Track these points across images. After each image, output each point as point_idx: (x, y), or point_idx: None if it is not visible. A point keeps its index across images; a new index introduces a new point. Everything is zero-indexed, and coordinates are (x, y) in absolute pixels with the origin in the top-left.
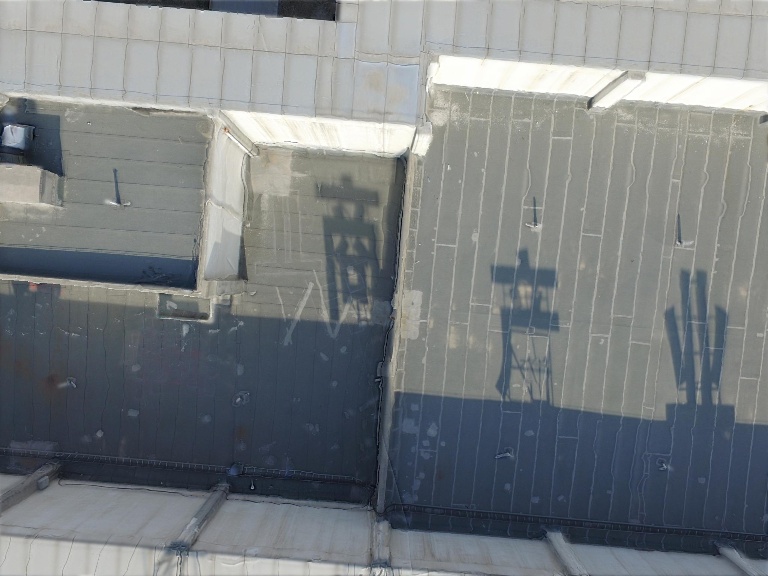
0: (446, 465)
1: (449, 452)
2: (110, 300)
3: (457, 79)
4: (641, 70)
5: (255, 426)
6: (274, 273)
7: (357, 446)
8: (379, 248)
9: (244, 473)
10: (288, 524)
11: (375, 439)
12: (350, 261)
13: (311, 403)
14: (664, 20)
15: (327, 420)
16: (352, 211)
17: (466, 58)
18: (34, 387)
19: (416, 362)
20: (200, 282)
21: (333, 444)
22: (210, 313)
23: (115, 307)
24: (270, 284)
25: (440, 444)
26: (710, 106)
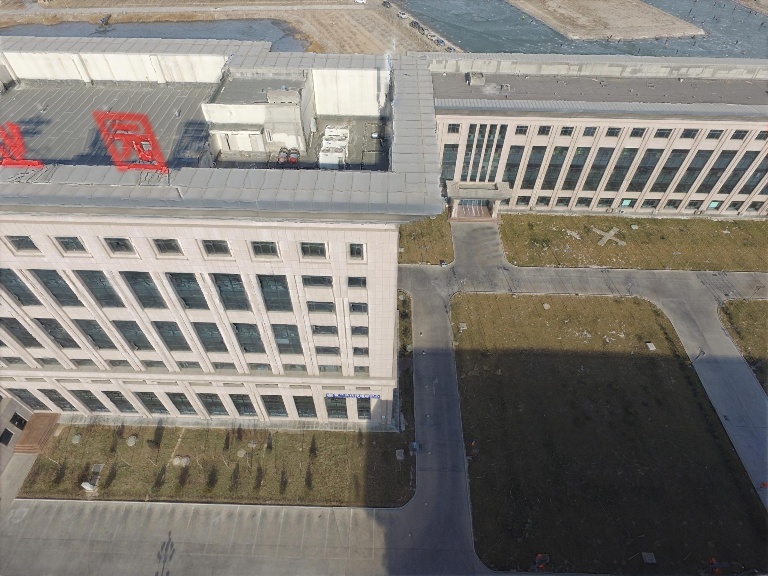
0: None
1: None
2: None
3: (25, 73)
4: (77, 52)
5: None
6: None
7: None
8: None
9: None
10: None
11: None
12: None
13: None
14: (91, 44)
15: None
16: None
17: (14, 54)
18: None
19: None
20: None
21: None
22: None
23: None
24: None
25: None
26: (135, 81)
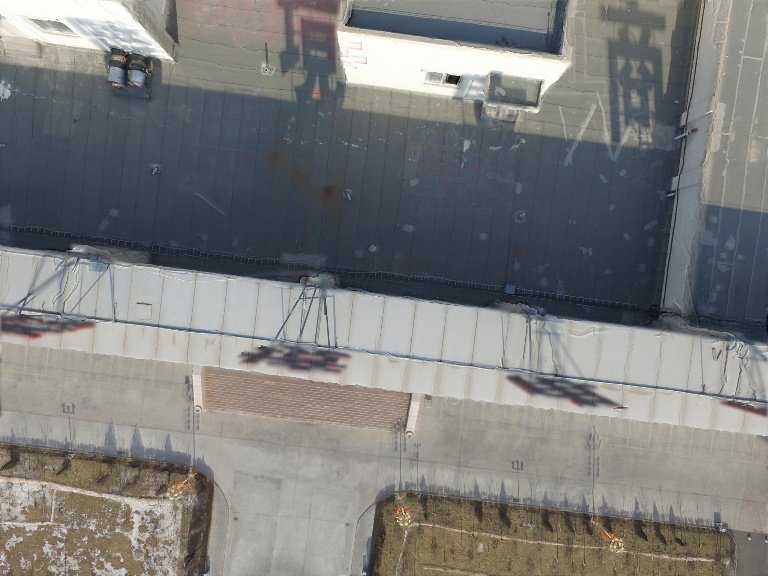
0: (742, 279)
1: (745, 266)
2: (393, 112)
3: None
4: None
5: (529, 247)
6: (559, 92)
7: (635, 268)
8: (666, 71)
9: (517, 293)
10: (594, 324)
11: (665, 255)
12: (634, 84)
13: (585, 227)
14: None
15: (602, 244)
16: (638, 34)
17: None
18: (309, 198)
19: (716, 174)
20: (565, 47)
21: (604, 269)
22: (539, 100)
23: (397, 119)
24: (555, 103)
25: (737, 257)
26: None
